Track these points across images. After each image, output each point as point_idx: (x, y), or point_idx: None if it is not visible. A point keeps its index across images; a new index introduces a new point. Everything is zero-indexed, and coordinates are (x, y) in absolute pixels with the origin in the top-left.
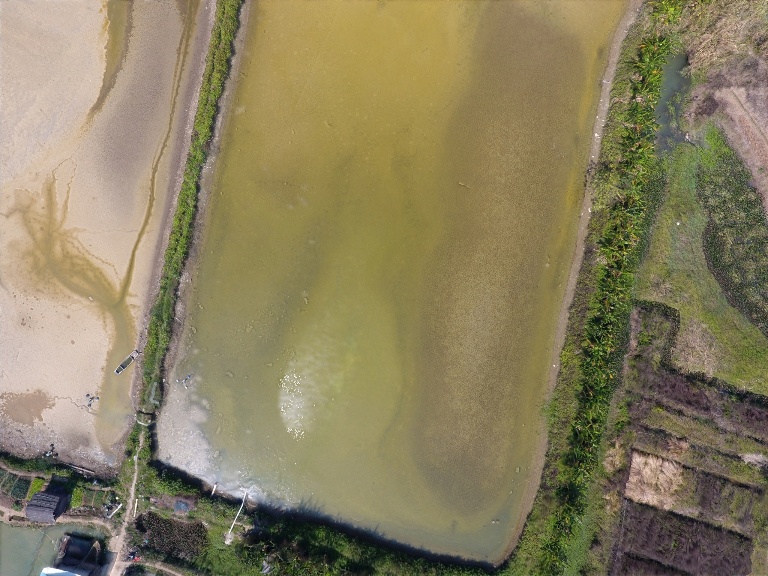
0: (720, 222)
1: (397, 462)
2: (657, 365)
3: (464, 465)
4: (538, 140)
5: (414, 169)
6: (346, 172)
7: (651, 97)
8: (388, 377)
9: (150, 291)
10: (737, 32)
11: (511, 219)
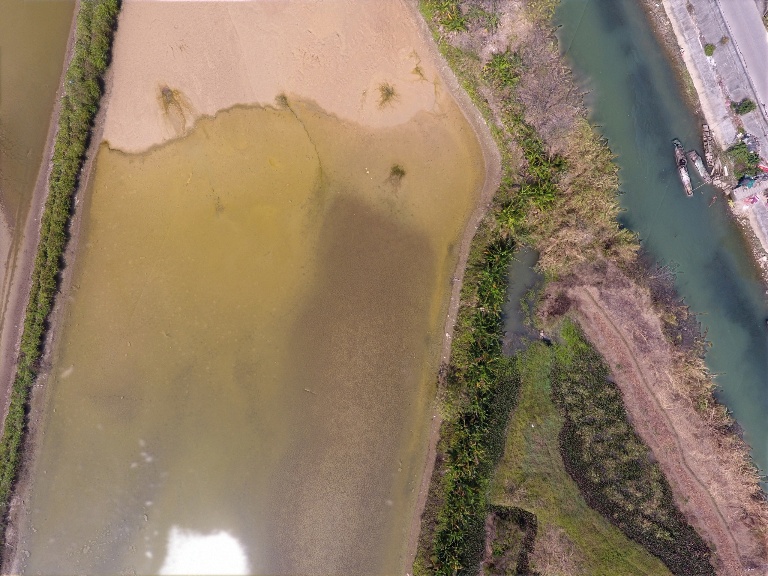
0: (578, 420)
1: None
2: (513, 573)
3: None
4: (387, 342)
5: (257, 377)
6: (186, 383)
7: (495, 306)
8: None
9: None
10: None
11: (360, 424)
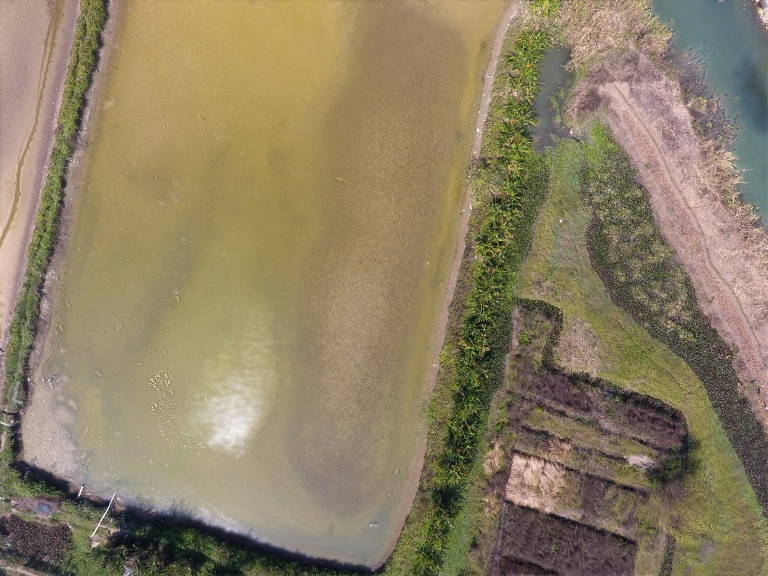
0: (605, 219)
1: (272, 463)
2: (539, 365)
3: (341, 467)
4: (418, 135)
5: (290, 164)
6: (219, 167)
7: (528, 91)
8: (263, 377)
9: (15, 288)
10: (616, 25)
11: (390, 216)
